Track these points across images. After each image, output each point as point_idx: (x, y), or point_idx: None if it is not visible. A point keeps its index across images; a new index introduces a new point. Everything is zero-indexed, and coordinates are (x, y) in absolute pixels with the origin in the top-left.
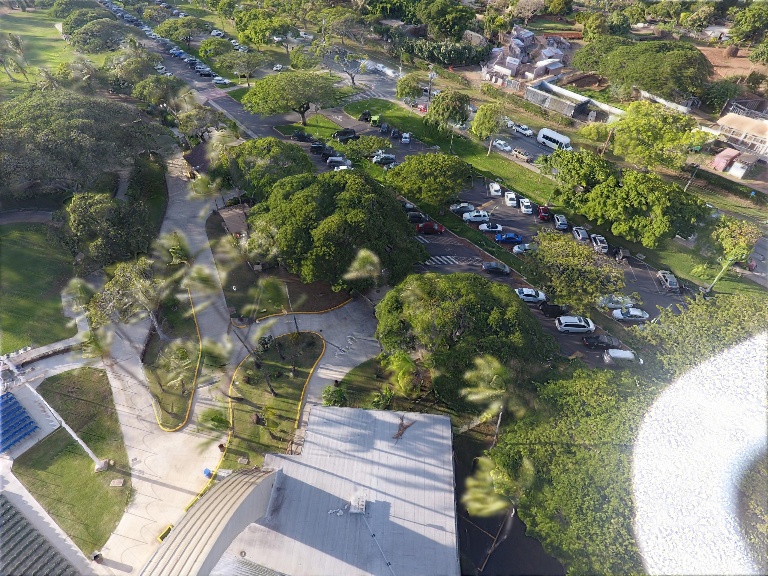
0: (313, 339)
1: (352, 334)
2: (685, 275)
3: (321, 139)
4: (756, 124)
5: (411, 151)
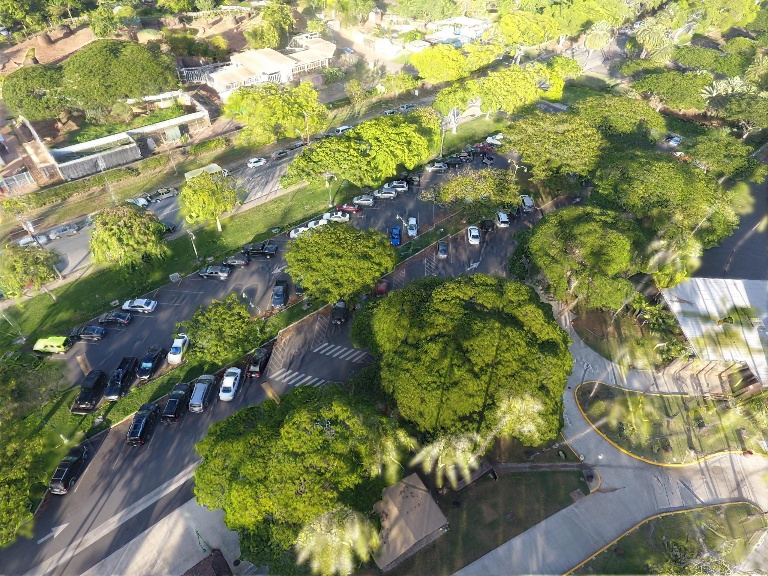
0: (585, 393)
1: None
2: (425, 161)
3: (91, 432)
4: (236, 71)
5: (181, 303)
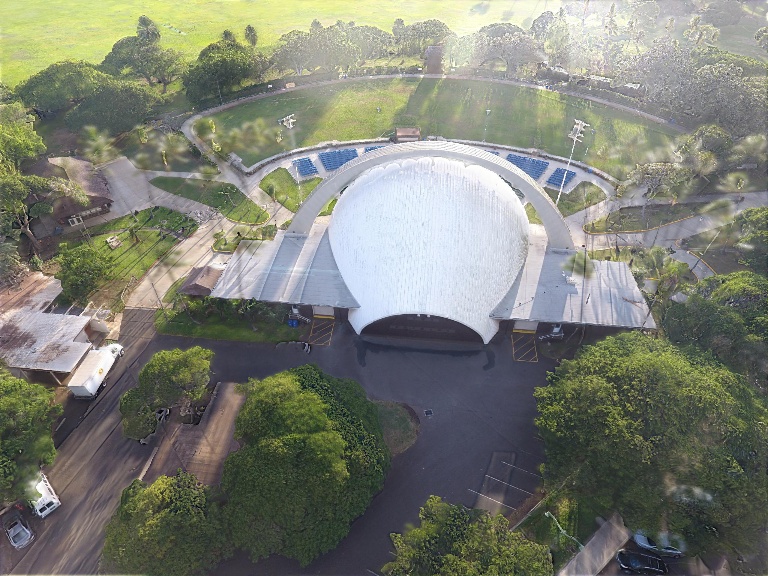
0: (691, 279)
1: None
2: None
3: None
4: None
5: None
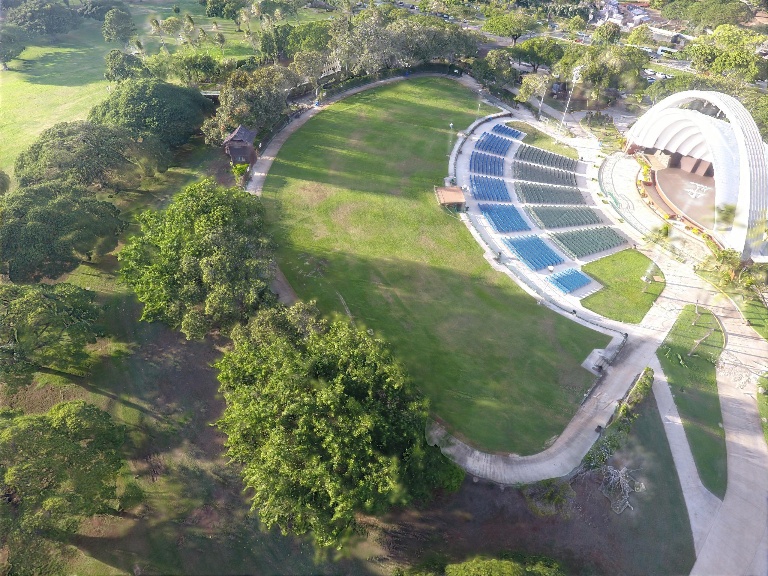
0: None
1: (621, 115)
2: None
3: None
4: None
5: None
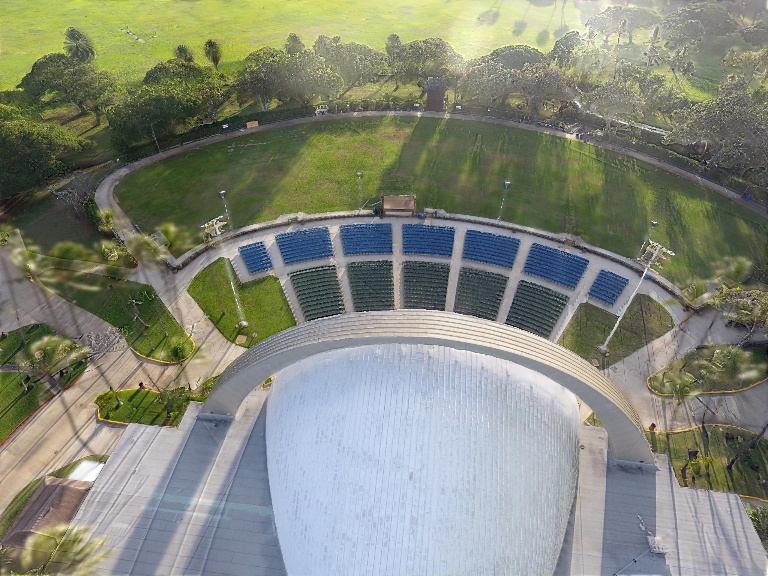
0: None
1: None
2: None
3: None
4: None
5: None
